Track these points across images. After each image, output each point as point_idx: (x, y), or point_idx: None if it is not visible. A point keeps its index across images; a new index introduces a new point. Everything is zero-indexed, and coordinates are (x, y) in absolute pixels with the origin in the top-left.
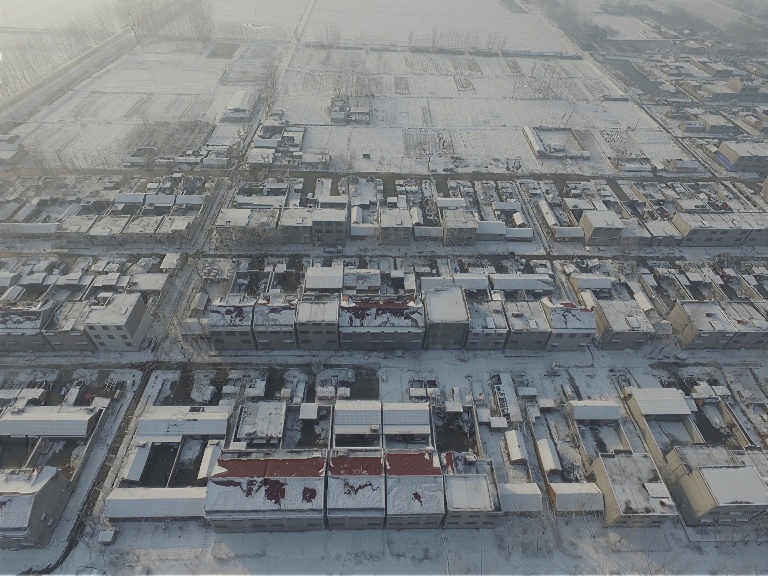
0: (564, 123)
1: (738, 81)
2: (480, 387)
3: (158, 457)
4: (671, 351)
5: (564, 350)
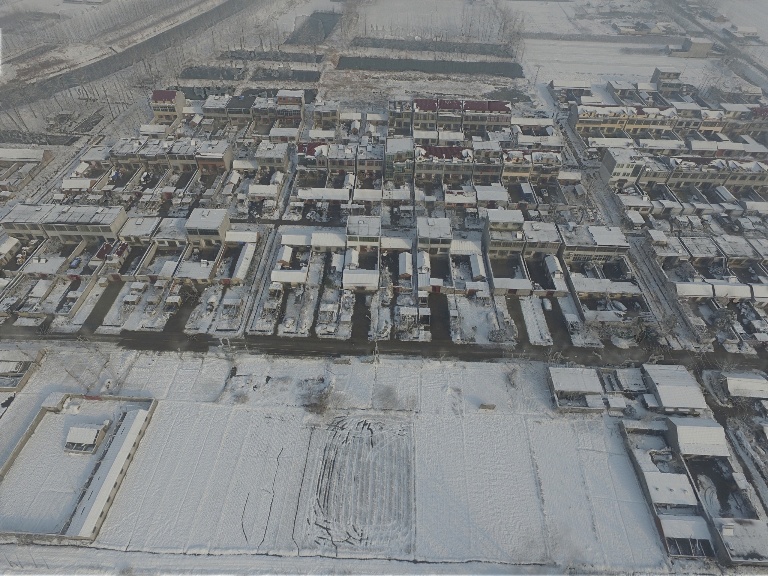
0: None
1: None
2: None
3: None
4: None
5: None
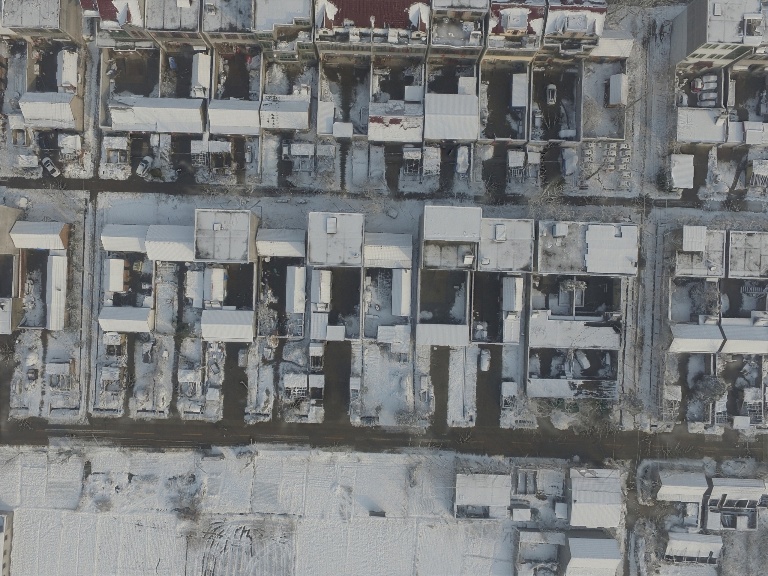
0: None
1: None
2: None
3: None
4: None
5: None
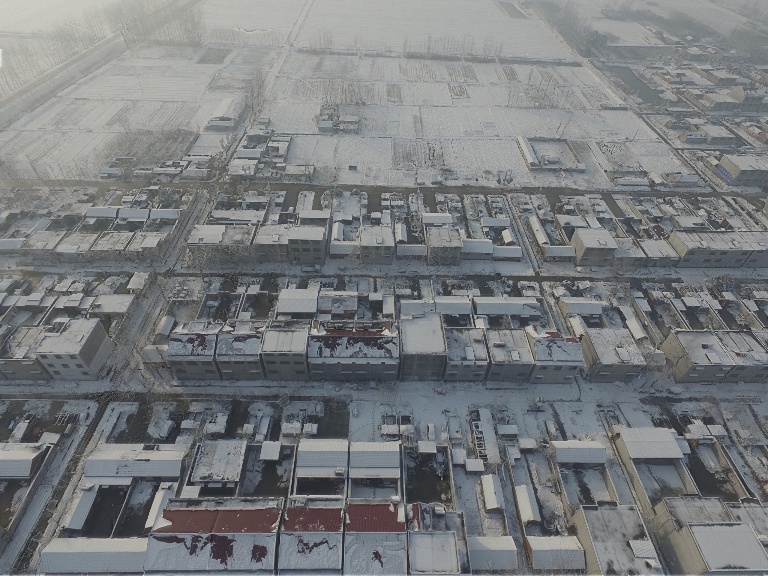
0: (560, 133)
1: (741, 90)
2: (457, 423)
3: (106, 501)
4: (664, 384)
5: (549, 382)
